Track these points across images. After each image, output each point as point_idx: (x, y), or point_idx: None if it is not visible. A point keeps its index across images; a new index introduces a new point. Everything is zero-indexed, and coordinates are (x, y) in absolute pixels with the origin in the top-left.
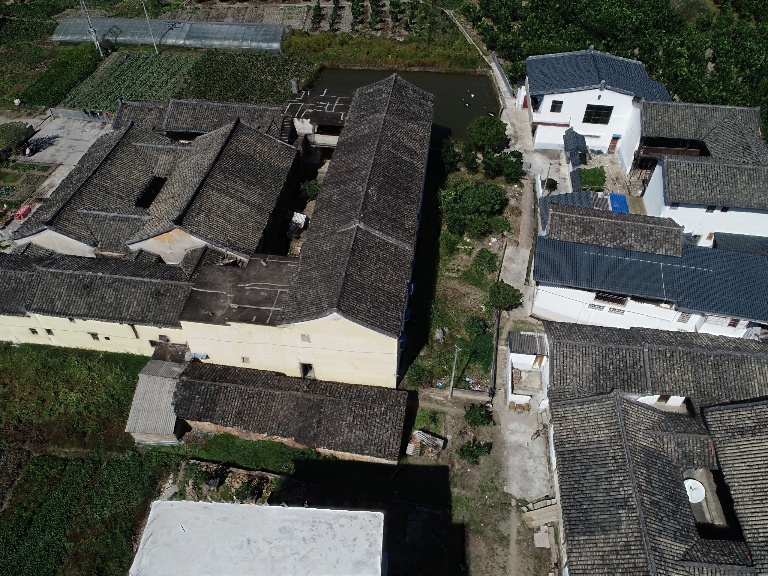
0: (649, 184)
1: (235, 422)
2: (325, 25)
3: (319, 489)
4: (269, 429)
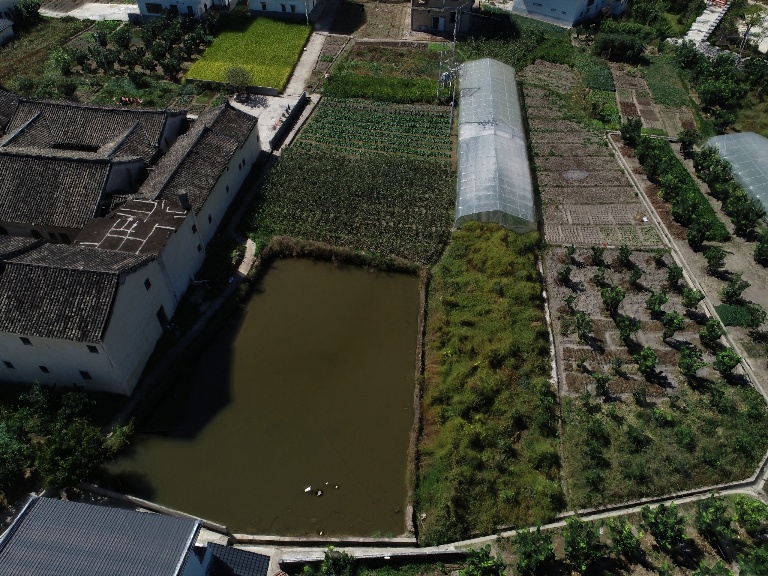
0: None
1: None
2: (590, 272)
3: None
4: None
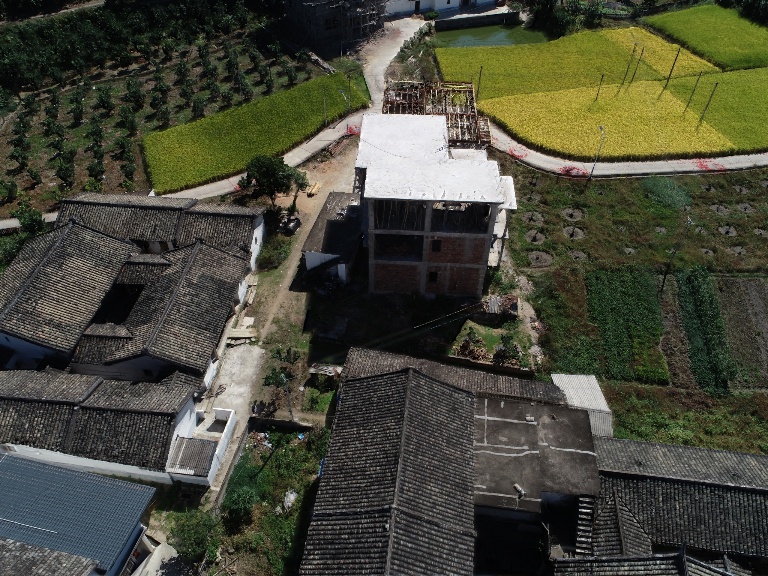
0: None
1: (498, 377)
2: None
3: (415, 350)
4: (465, 371)
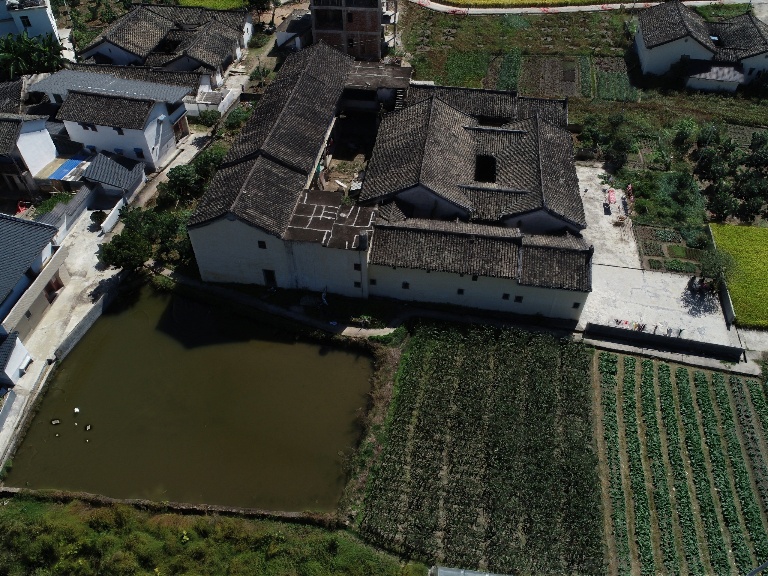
0: (27, 161)
1: None
2: None
3: None
4: None
